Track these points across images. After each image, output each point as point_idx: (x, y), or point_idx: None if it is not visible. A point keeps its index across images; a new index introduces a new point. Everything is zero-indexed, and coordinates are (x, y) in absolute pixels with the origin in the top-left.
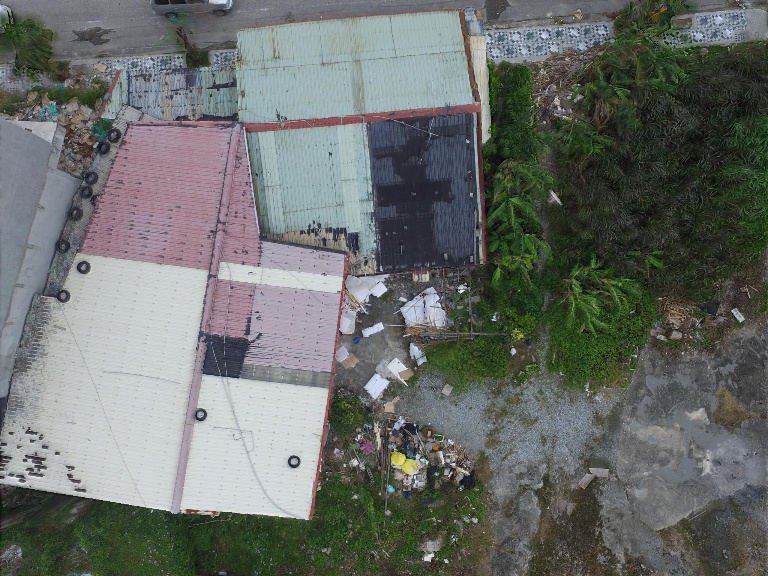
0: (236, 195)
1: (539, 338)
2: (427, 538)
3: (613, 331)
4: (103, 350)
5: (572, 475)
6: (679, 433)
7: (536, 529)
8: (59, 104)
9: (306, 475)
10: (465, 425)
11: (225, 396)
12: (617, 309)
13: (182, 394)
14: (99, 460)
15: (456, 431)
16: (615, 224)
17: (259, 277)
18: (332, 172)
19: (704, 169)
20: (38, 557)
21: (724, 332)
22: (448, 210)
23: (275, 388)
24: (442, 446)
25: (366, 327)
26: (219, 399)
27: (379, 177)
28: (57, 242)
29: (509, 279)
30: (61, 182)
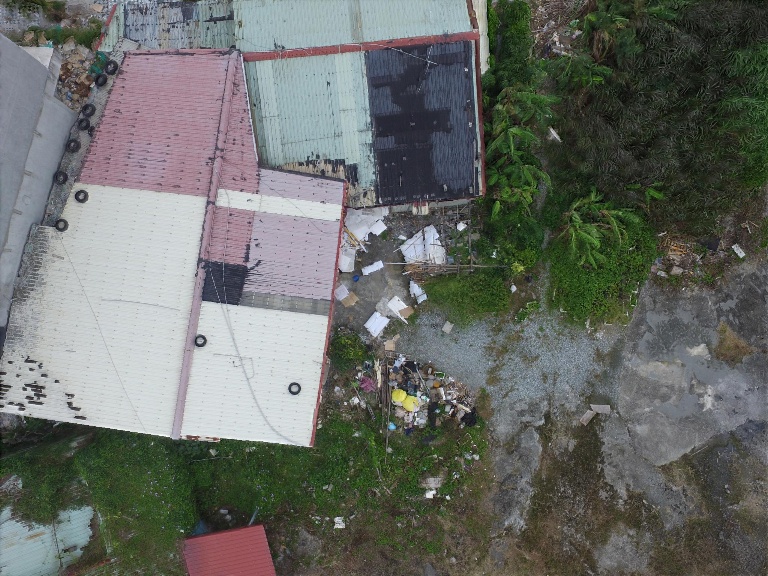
0: (234, 122)
1: (539, 275)
2: (428, 475)
3: (613, 266)
4: (102, 278)
5: (573, 412)
6: (680, 369)
7: (538, 466)
8: (56, 43)
9: (307, 402)
10: (466, 362)
11: (225, 323)
12: (617, 242)
13: (181, 321)
14: (99, 387)
15: (457, 369)
16: (615, 154)
17: (258, 204)
18: (330, 102)
19: (704, 99)
20: (39, 487)
21: (725, 268)
22: (447, 140)
23: (275, 315)
24: (443, 383)
25: (366, 265)
26: (219, 326)
27: (377, 107)
28: (55, 174)
29: (509, 213)
30: (58, 111)
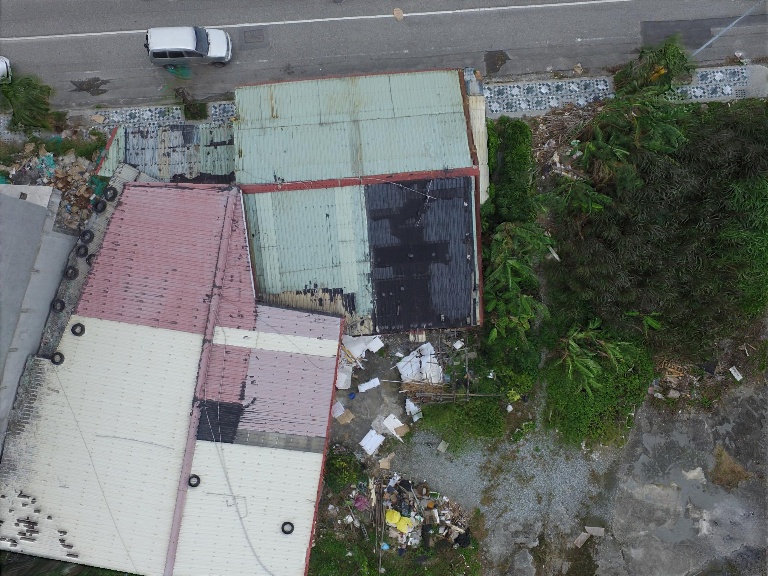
0: (232, 259)
1: (536, 395)
2: None
3: (610, 390)
4: (97, 414)
5: (568, 533)
6: (676, 492)
7: None
8: (56, 155)
9: (299, 541)
10: (461, 482)
11: (219, 462)
12: (614, 369)
13: (175, 460)
14: (91, 525)
15: (451, 488)
16: (613, 287)
17: (254, 341)
18: (329, 233)
19: (703, 231)
20: None
21: (722, 391)
22: (445, 272)
23: (269, 453)
24: (437, 503)
25: (362, 382)
26: (213, 465)
27: (376, 239)
28: (52, 302)
29: (506, 338)
30: (56, 243)
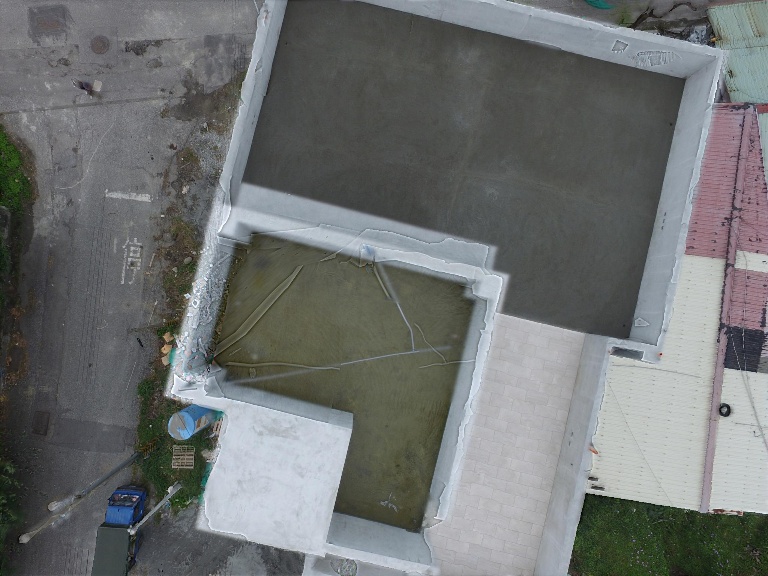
0: (749, 180)
1: None
2: None
3: None
4: None
5: None
6: None
7: None
8: None
9: None
10: None
11: (745, 391)
12: None
13: (704, 389)
14: (616, 457)
15: None
16: None
17: None
18: None
19: None
20: None
21: None
22: None
23: None
24: None
25: None
26: (739, 394)
27: None
28: None
29: None
30: None
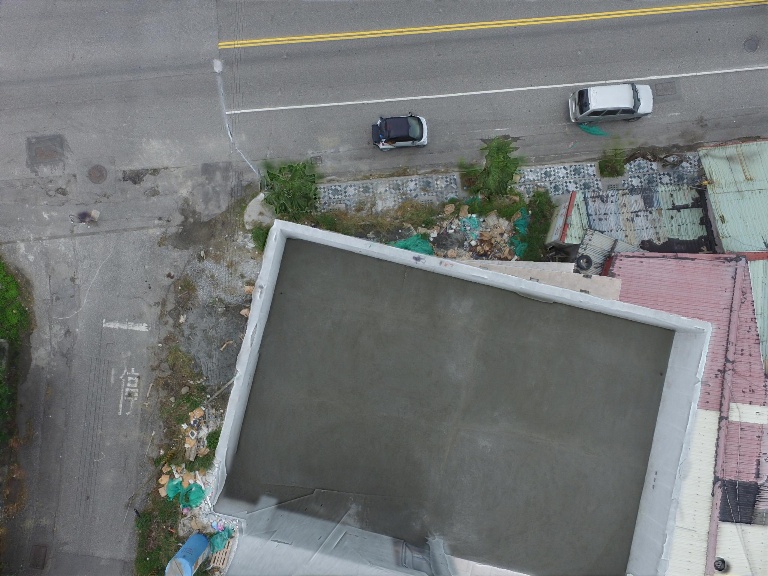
0: (742, 332)
1: None
2: None
3: None
4: None
5: None
6: None
7: None
8: (477, 217)
9: None
10: None
11: (739, 543)
12: None
13: (699, 542)
14: None
15: None
16: None
17: (765, 417)
18: None
19: None
20: None
21: None
22: None
23: None
24: None
25: None
26: (734, 547)
27: None
28: None
29: None
30: None
